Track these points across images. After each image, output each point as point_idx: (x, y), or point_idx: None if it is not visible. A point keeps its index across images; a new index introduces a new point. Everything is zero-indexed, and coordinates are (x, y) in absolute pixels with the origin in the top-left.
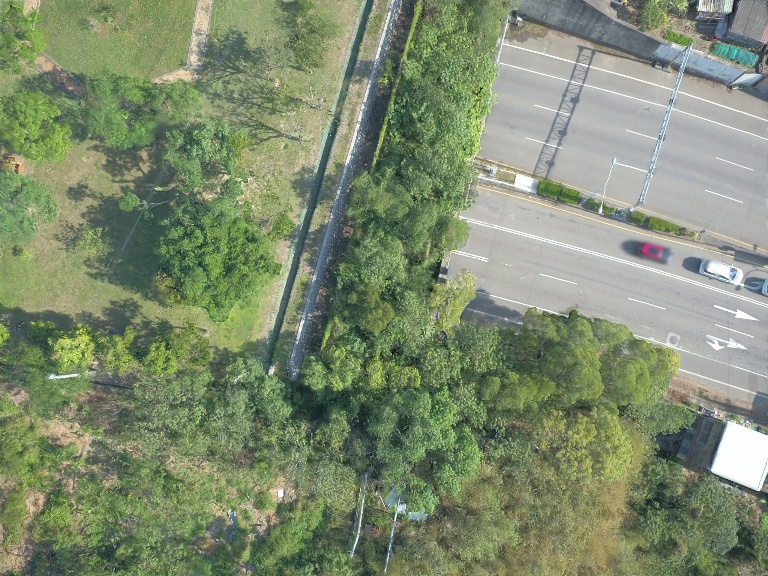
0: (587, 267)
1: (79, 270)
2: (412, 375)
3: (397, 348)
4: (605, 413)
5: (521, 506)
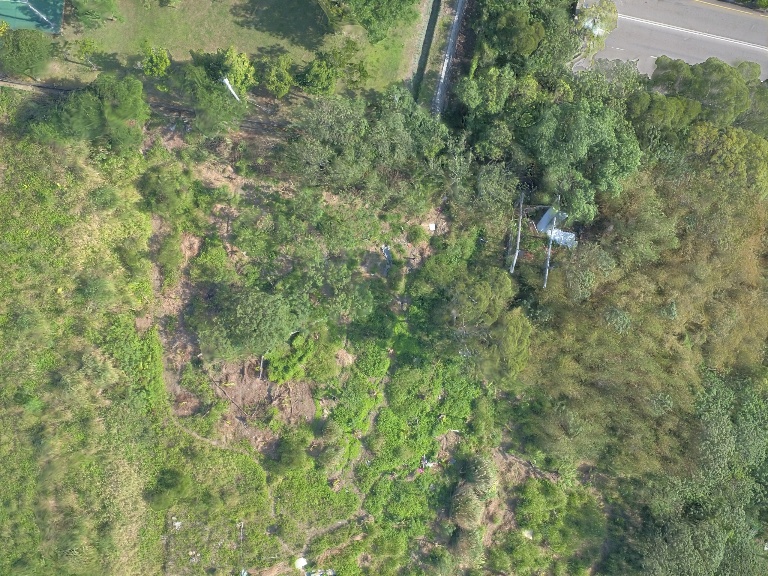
0: (697, 48)
1: (225, 18)
2: (566, 90)
3: (543, 77)
4: (750, 132)
5: (680, 210)
